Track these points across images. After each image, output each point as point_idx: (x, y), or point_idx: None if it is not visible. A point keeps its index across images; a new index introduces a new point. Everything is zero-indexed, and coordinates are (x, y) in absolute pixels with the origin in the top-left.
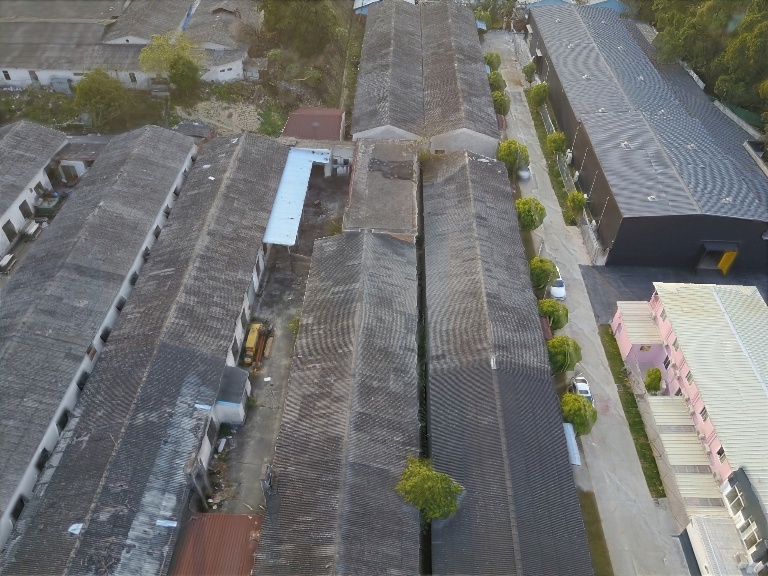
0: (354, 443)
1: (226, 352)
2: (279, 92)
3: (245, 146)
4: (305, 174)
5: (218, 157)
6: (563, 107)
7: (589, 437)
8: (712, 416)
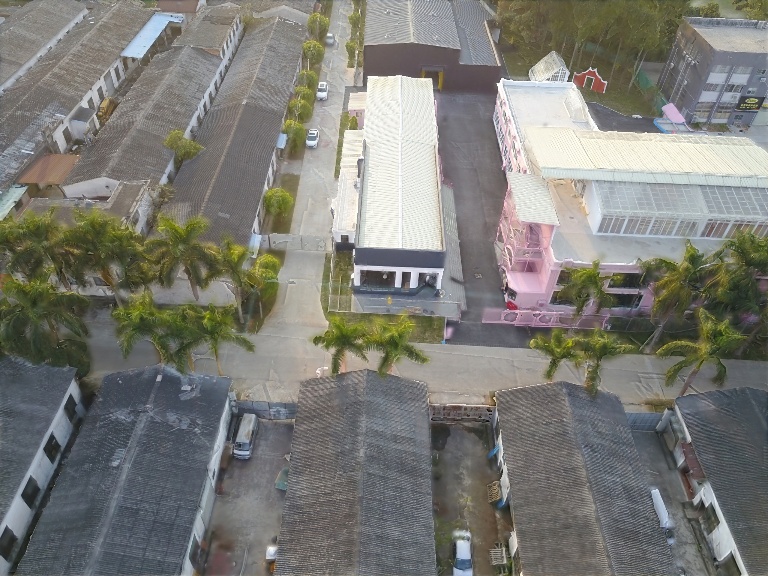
0: (142, 123)
1: (81, 97)
2: None
3: (120, 7)
4: (161, 26)
5: (100, 13)
6: None
7: (310, 155)
8: (365, 125)
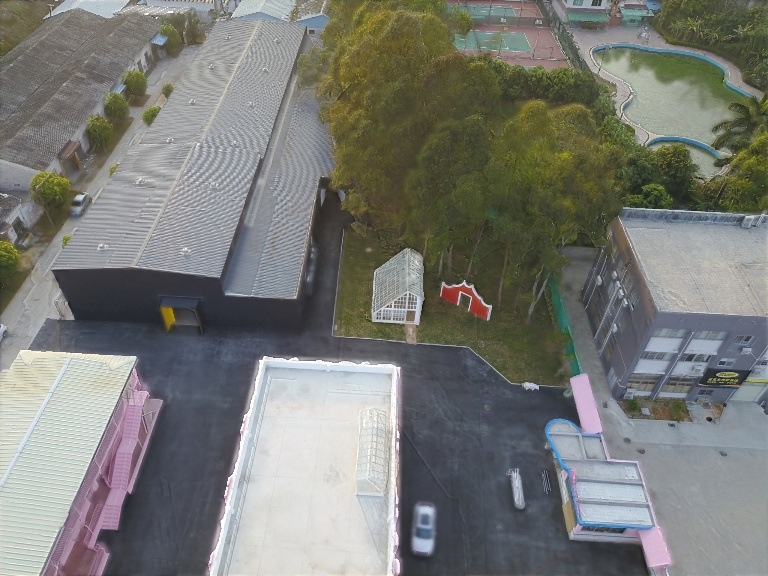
0: None
1: None
2: None
3: None
4: None
5: None
6: None
7: None
8: None
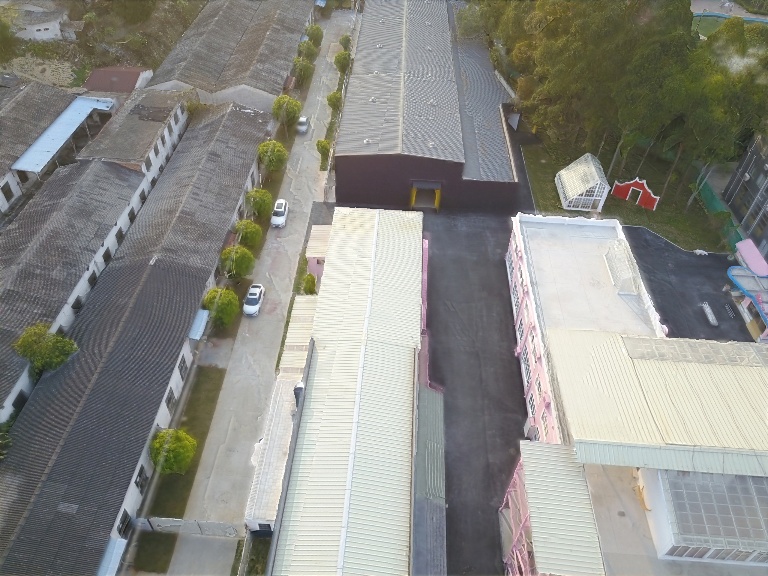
0: None
1: None
2: (95, 52)
3: (29, 92)
4: (80, 118)
5: (2, 100)
6: None
7: (246, 330)
8: (318, 303)
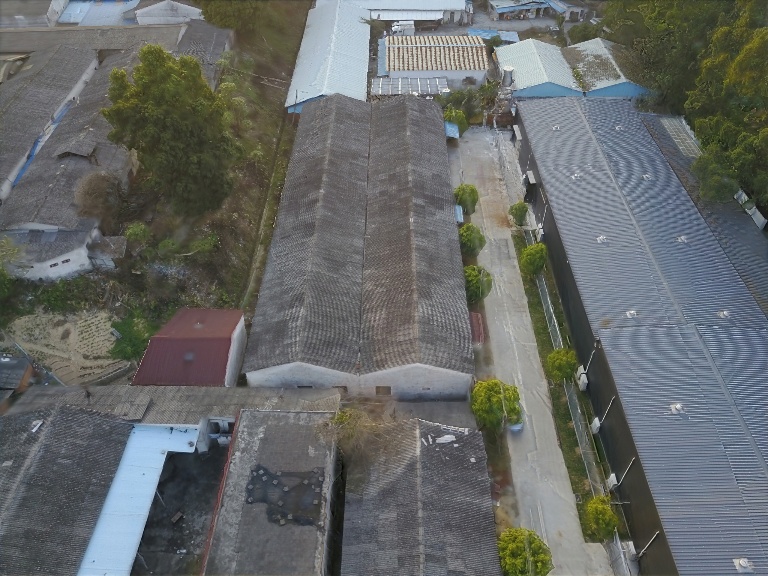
0: None
1: None
2: (146, 285)
3: (49, 441)
4: (147, 489)
5: (1, 467)
6: (570, 288)
7: None
8: None
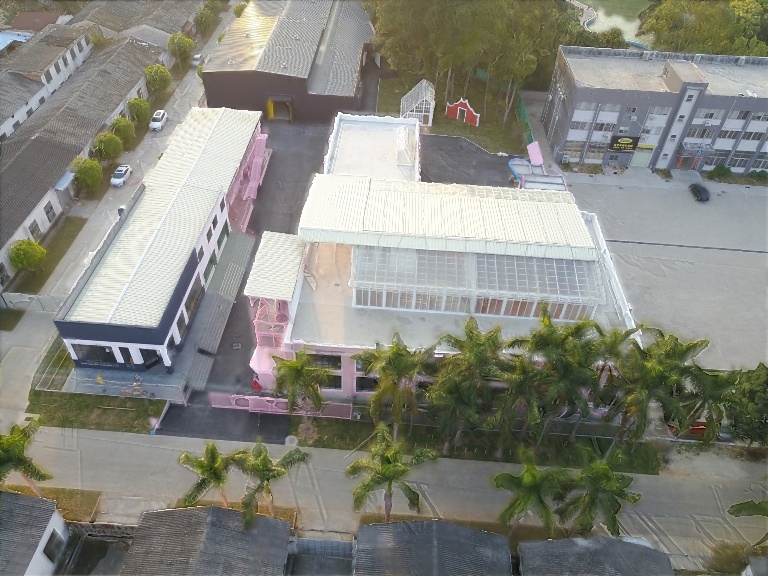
0: None
1: None
2: (25, 0)
3: None
4: (1, 46)
5: None
6: None
7: (111, 195)
8: (157, 165)
